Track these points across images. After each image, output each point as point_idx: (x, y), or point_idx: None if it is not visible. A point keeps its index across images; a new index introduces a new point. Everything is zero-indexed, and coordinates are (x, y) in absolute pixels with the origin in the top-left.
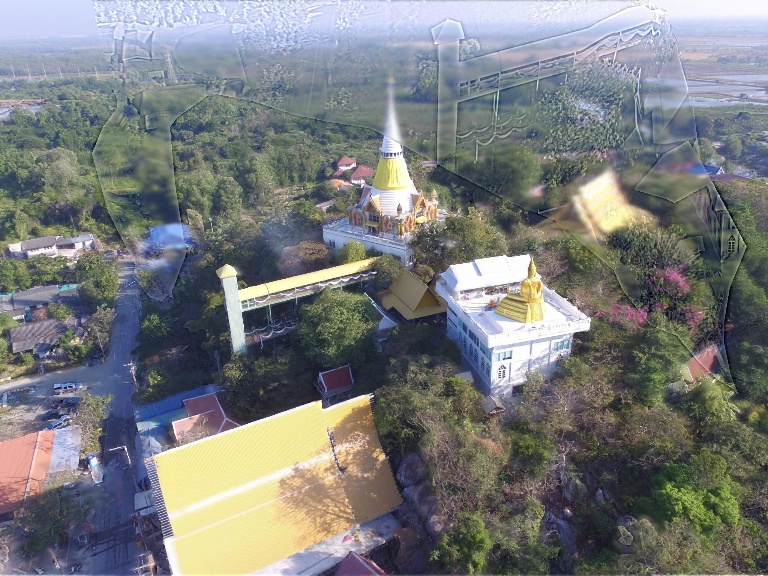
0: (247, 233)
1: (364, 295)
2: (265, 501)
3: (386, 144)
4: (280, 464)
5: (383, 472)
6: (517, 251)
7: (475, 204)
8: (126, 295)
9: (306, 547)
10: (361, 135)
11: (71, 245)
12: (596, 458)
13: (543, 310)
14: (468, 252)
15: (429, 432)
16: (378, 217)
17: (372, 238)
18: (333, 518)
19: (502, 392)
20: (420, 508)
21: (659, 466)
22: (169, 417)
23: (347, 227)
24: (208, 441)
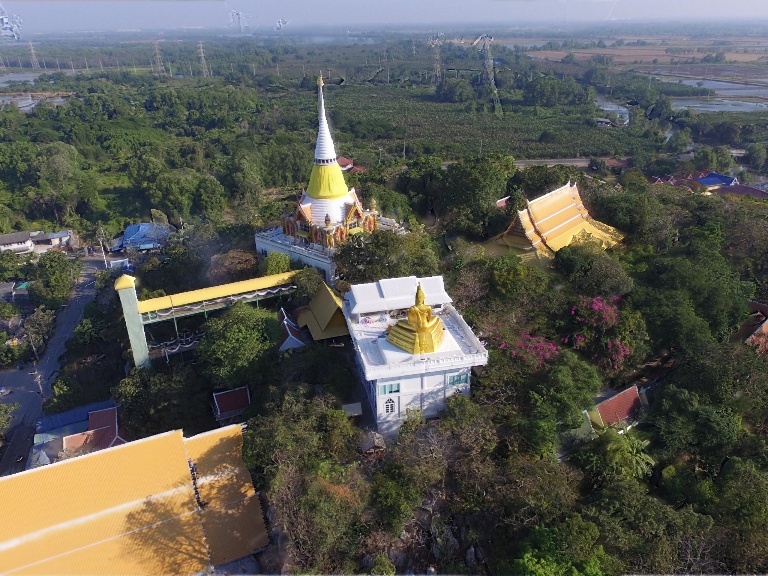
0: (200, 236)
1: (280, 310)
2: (107, 536)
3: (318, 150)
4: (129, 497)
5: (251, 509)
6: (451, 268)
7: (435, 213)
8: (83, 295)
9: None
10: (370, 134)
11: (48, 241)
12: (473, 511)
13: (436, 340)
14: (393, 268)
15: (276, 474)
16: (308, 227)
17: (299, 249)
18: (185, 558)
19: (391, 427)
20: (281, 552)
21: (528, 528)
22: (69, 430)
23: (282, 236)
24: (44, 470)
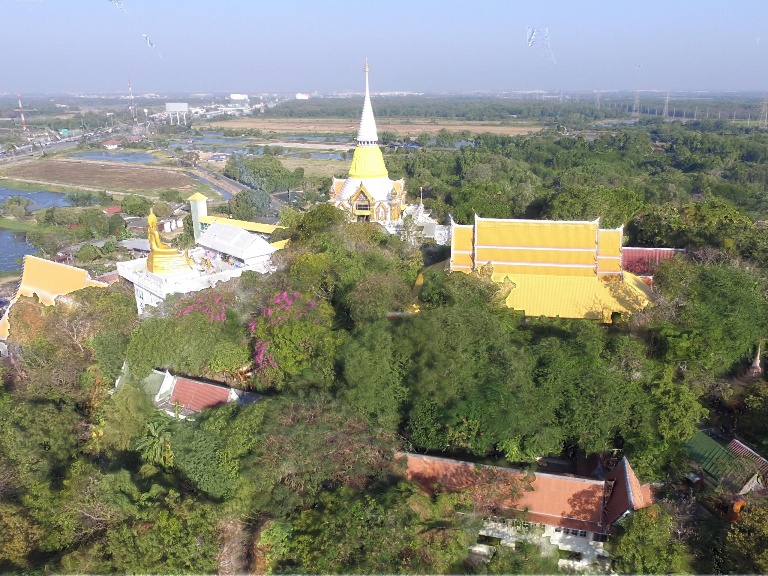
0: None
1: None
2: None
3: None
4: None
5: None
6: None
7: None
8: None
9: None
10: None
11: None
12: None
13: (161, 265)
14: None
15: None
16: None
17: None
18: None
19: None
20: None
21: None
22: None
23: None
24: None
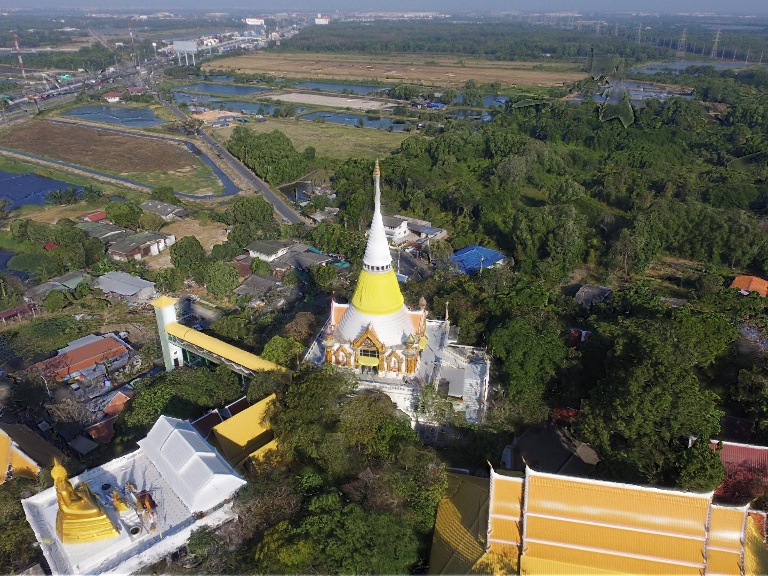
0: None
1: None
2: None
3: None
4: None
5: None
6: None
7: None
8: None
9: None
10: None
11: (420, 233)
12: None
13: (74, 533)
14: None
15: None
16: None
17: None
18: None
19: None
20: None
21: None
22: None
23: None
24: None
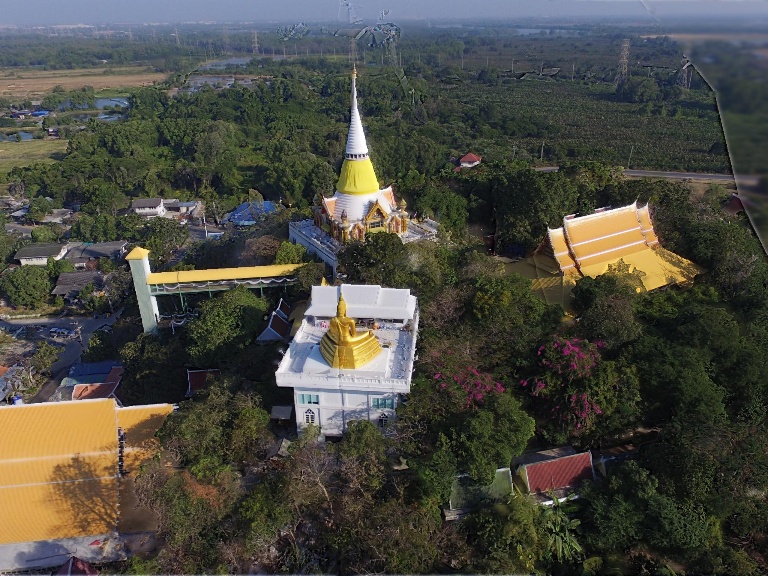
0: (272, 219)
1: (279, 300)
2: (34, 481)
3: (348, 144)
4: (61, 450)
5: None
6: None
7: (496, 221)
8: (178, 260)
9: (55, 538)
10: (519, 132)
11: (178, 208)
12: None
13: (360, 357)
14: None
15: None
16: None
17: (316, 242)
18: (95, 518)
19: None
20: None
21: None
22: (90, 379)
23: None
24: None
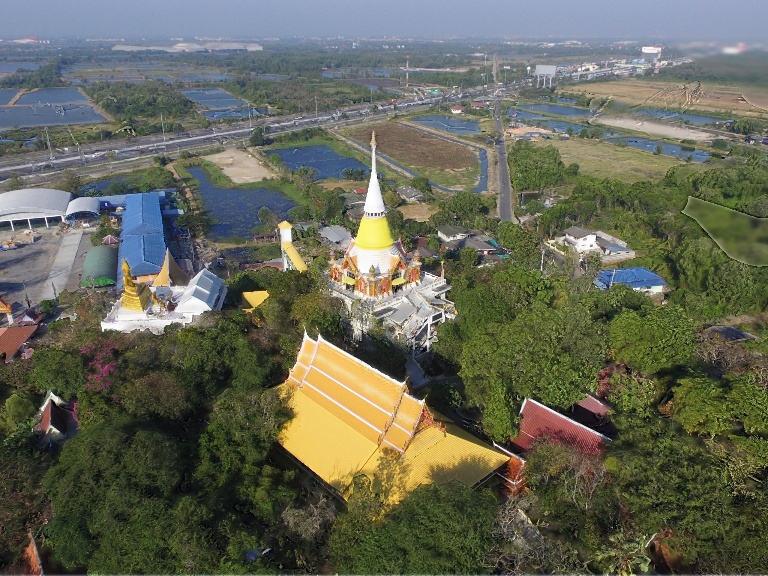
0: None
1: None
2: None
3: None
4: None
5: None
6: None
7: None
8: None
9: None
10: None
11: None
12: None
13: None
14: None
15: None
16: None
17: None
18: None
19: None
20: None
21: None
22: None
23: None
24: None
